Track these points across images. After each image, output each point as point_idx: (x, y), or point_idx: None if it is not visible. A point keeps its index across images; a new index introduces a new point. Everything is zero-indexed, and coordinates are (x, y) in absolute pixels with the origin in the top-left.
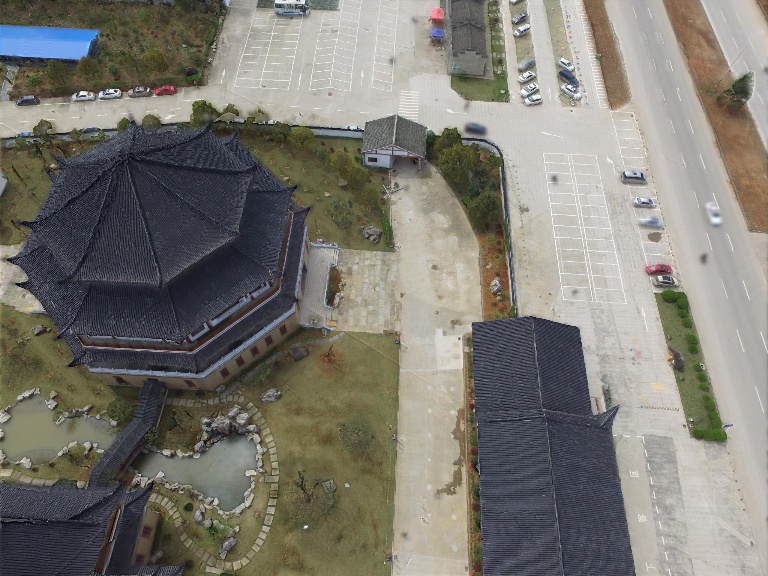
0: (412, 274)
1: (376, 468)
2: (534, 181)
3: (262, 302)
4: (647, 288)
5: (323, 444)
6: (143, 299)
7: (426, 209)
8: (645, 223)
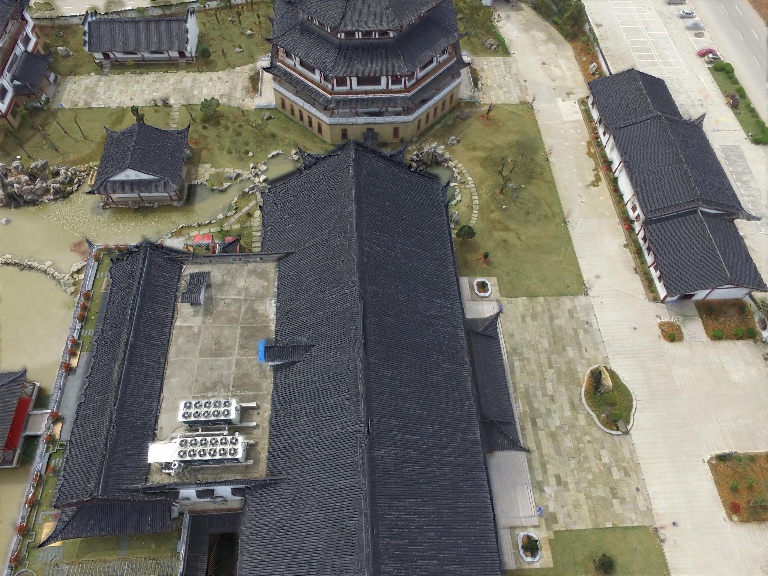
0: (529, 68)
1: (540, 176)
2: (602, 8)
3: (447, 65)
4: (701, 65)
5: (499, 166)
6: (379, 50)
7: (526, 30)
8: (690, 27)
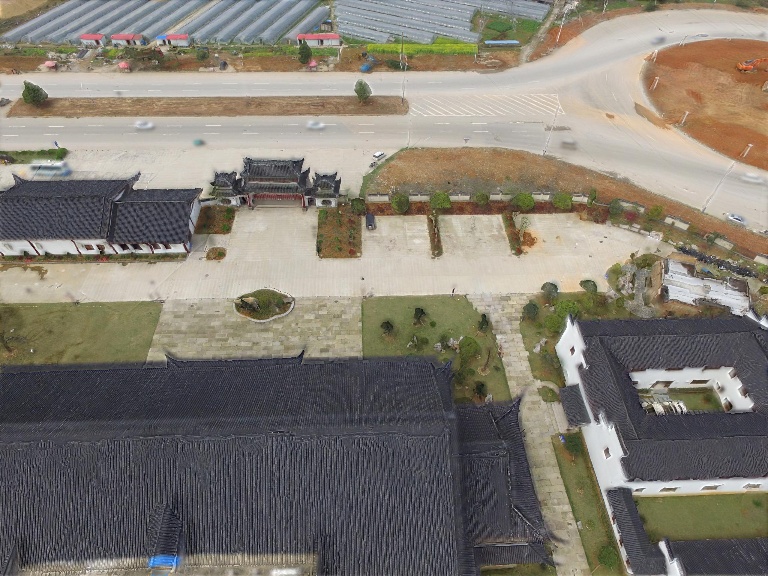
0: None
1: (7, 314)
2: None
3: None
4: None
5: None
6: None
7: None
8: None
